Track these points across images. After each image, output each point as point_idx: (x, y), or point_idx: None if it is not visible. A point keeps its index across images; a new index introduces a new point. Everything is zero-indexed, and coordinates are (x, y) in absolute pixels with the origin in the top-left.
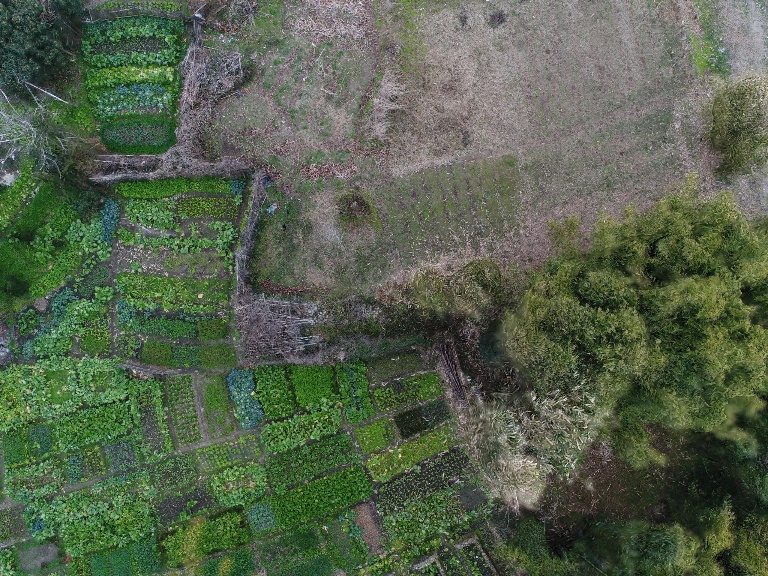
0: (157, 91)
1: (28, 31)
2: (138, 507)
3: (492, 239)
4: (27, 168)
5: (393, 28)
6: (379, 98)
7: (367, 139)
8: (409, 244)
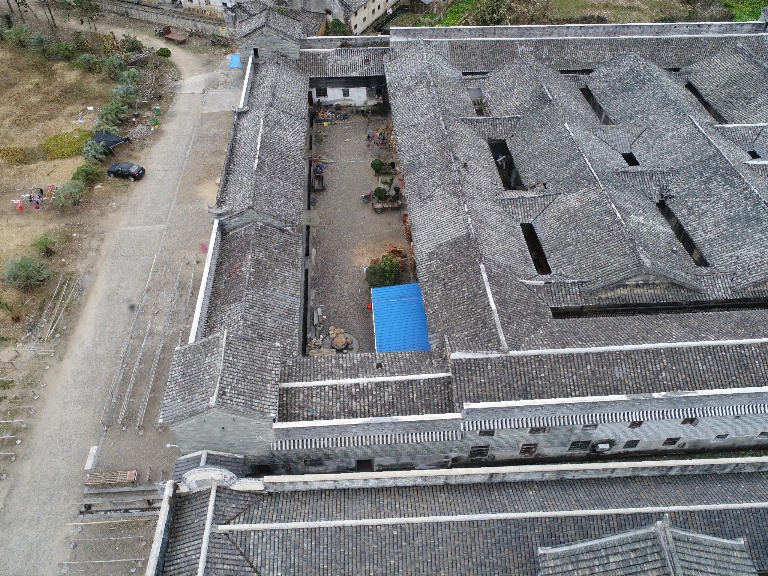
0: None
1: None
2: None
3: None
4: None
5: (601, 4)
6: (625, 6)
7: (640, 8)
8: (669, 5)
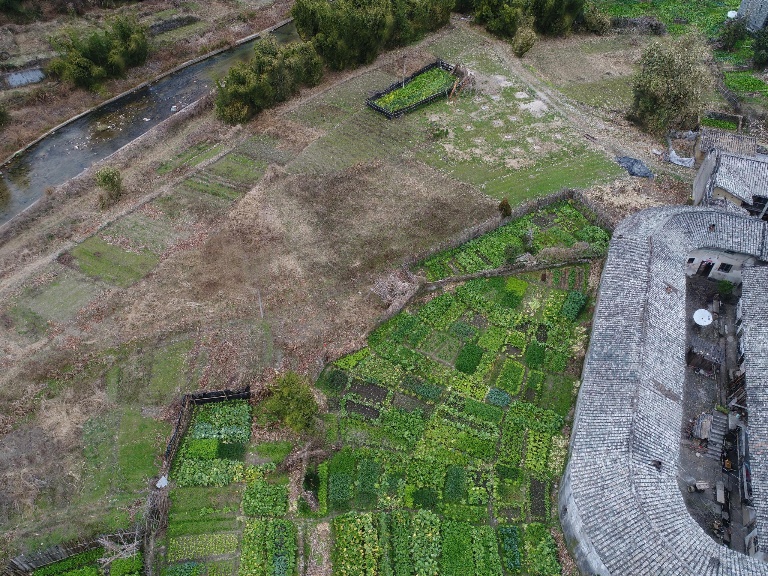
0: (717, 59)
1: (763, 38)
2: (664, 8)
3: (585, 42)
4: (748, 48)
5: None
6: None
7: None
8: None
